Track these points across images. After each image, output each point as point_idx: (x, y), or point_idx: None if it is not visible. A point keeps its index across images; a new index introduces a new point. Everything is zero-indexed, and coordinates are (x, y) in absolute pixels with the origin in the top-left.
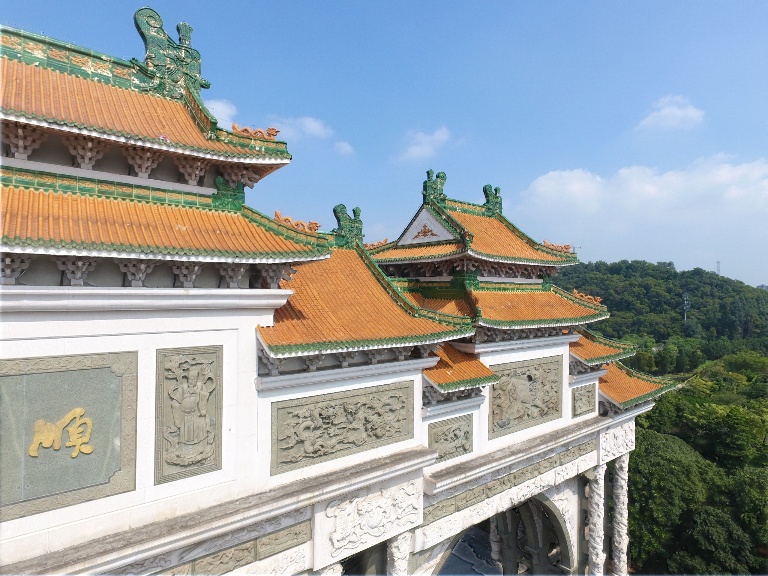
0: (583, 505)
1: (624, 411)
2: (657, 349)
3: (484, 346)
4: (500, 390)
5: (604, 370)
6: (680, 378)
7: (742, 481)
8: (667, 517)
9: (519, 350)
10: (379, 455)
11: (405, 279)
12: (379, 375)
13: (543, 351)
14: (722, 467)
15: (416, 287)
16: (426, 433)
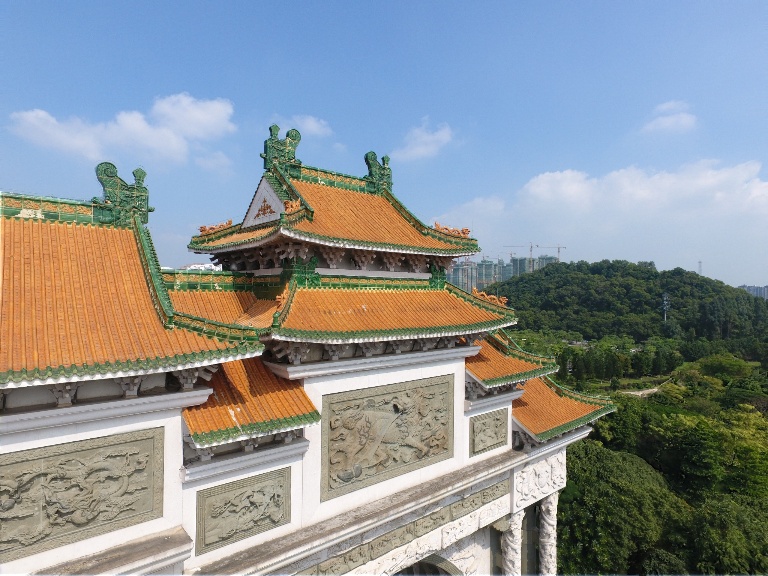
0: (497, 561)
1: (547, 442)
2: (635, 350)
3: (305, 368)
4: (344, 429)
5: (518, 391)
6: (656, 381)
7: (701, 517)
8: (614, 561)
9: (378, 371)
10: (80, 553)
11: (228, 272)
12: (81, 423)
13: (421, 370)
14: (688, 488)
15: (248, 283)
16: (192, 506)
